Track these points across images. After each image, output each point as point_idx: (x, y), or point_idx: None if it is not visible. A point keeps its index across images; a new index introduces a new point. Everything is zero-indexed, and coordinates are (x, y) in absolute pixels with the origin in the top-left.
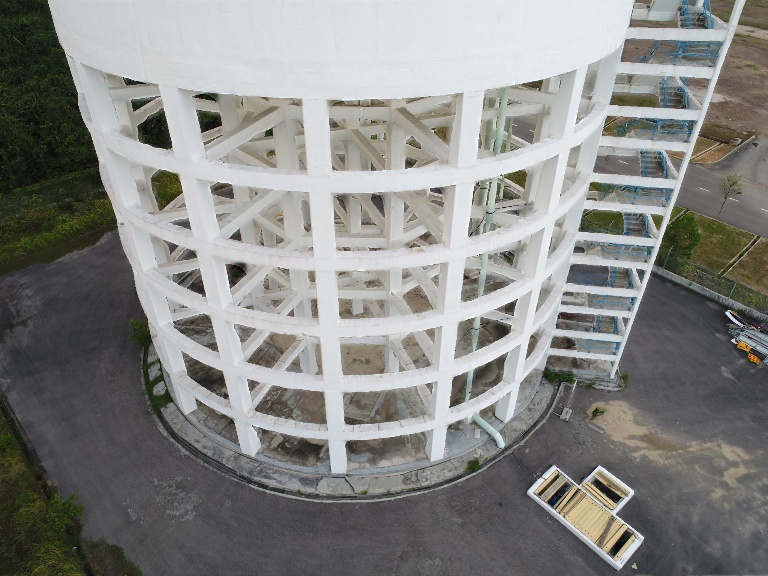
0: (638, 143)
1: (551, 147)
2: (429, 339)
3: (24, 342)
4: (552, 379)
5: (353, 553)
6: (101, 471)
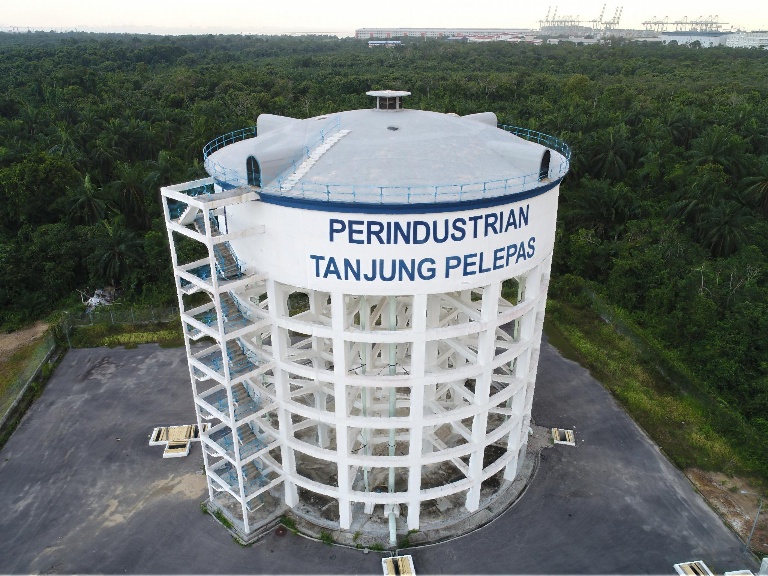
0: None
1: None
2: None
3: None
4: None
5: None
6: None
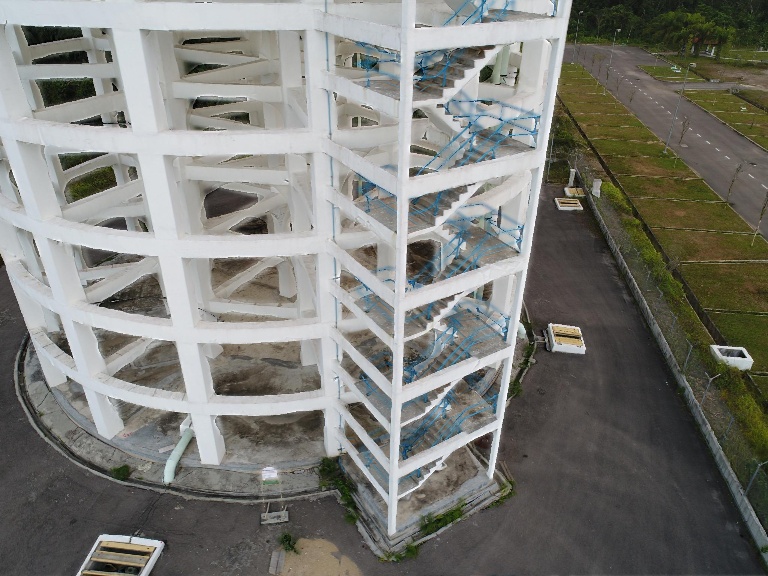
0: (352, 90)
1: (83, 7)
2: (113, 278)
3: None
4: (326, 474)
5: None
6: (6, 287)
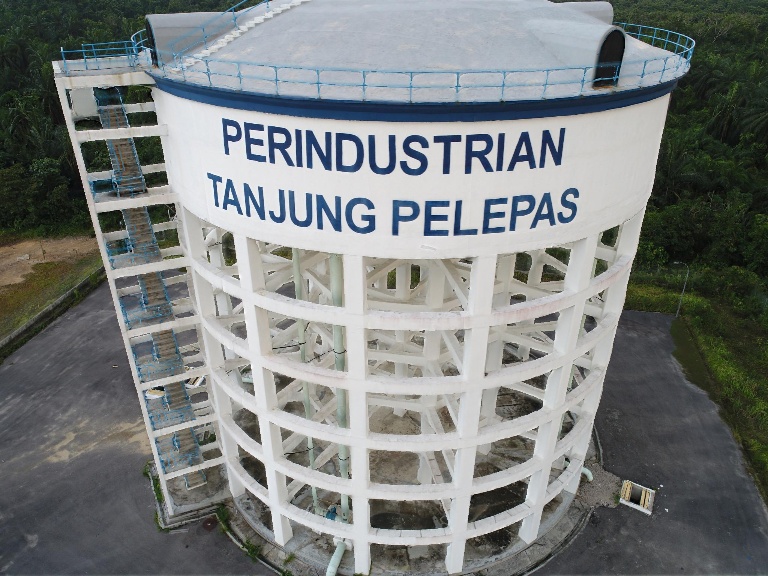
0: None
1: None
2: None
3: None
4: None
5: (287, 322)
6: None
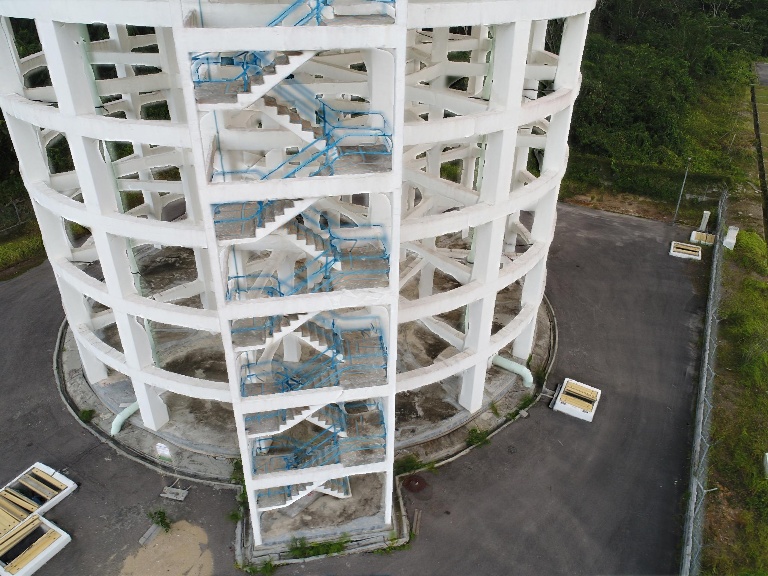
0: None
1: None
2: None
3: None
4: None
5: None
6: None
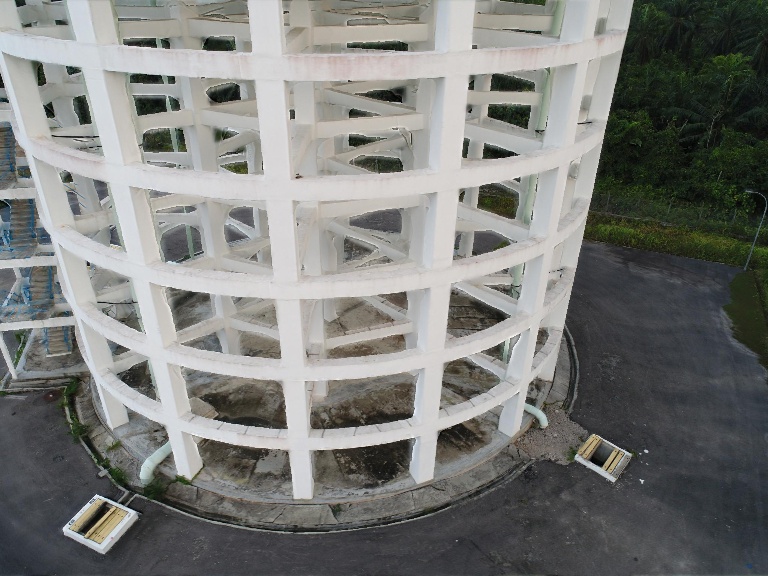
0: None
1: None
2: None
3: (594, 254)
4: None
5: None
6: None
